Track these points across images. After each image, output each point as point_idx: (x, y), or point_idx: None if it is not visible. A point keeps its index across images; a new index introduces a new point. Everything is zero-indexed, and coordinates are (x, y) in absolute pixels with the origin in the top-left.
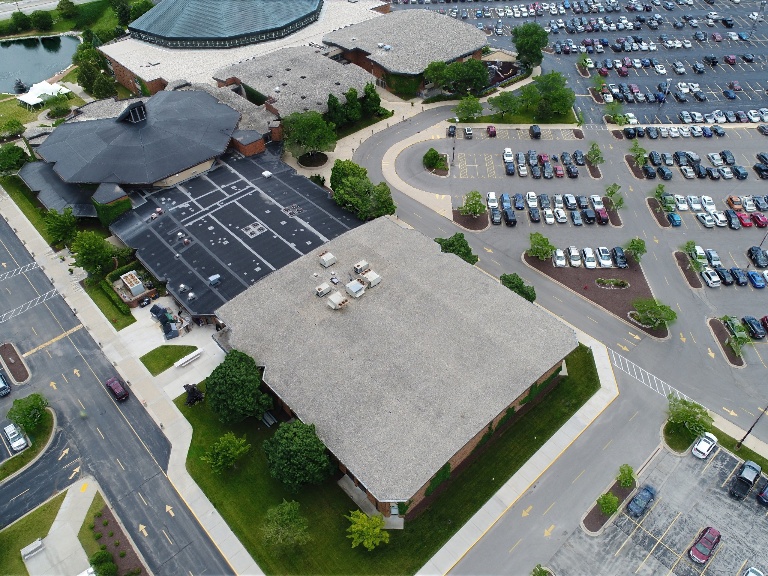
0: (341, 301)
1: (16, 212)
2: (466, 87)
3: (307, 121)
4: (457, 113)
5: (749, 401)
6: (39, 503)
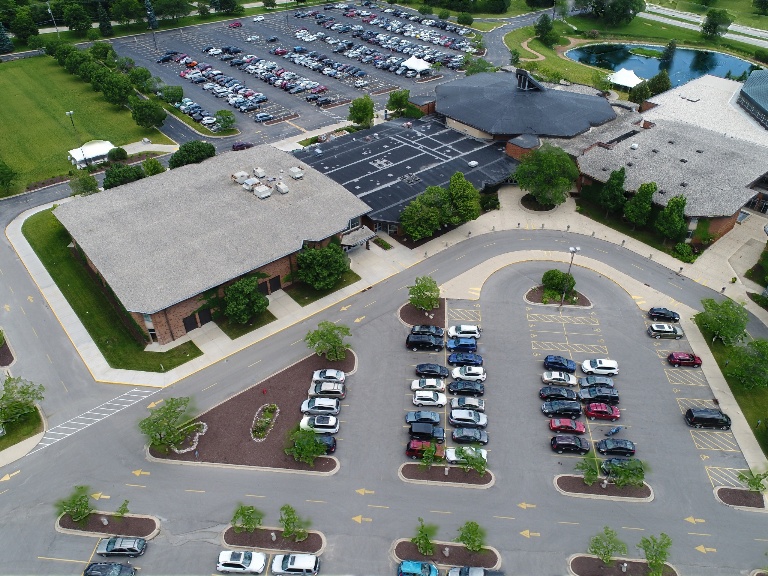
0: (236, 176)
1: None
2: None
3: (542, 154)
4: None
5: (8, 503)
6: (175, 140)
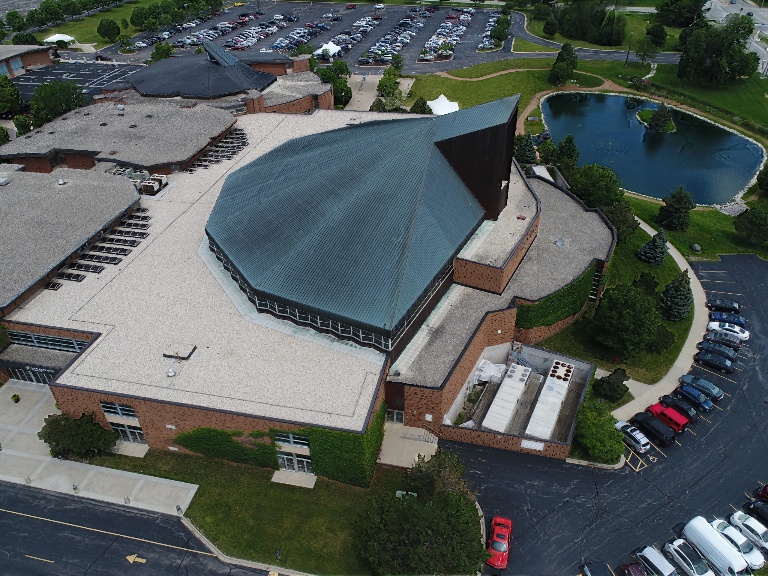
0: None
1: None
2: None
3: None
4: None
5: None
6: None
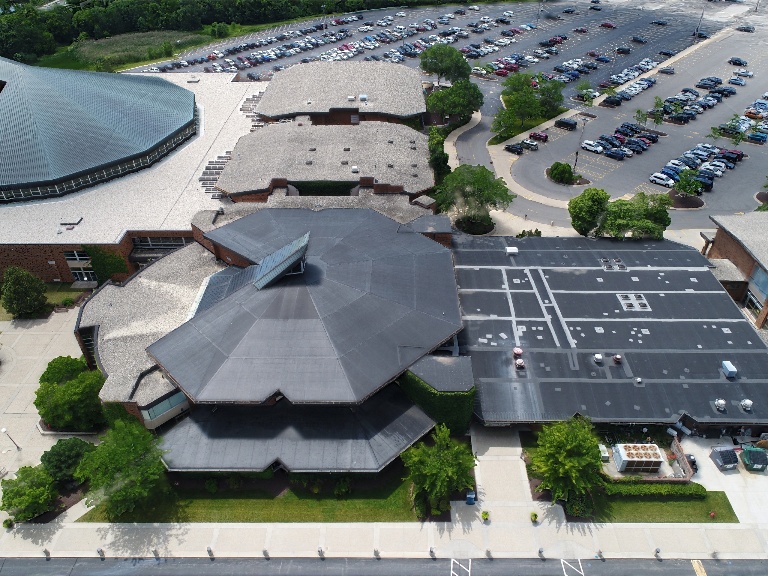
0: None
1: (251, 531)
2: (473, 109)
3: (483, 174)
4: (500, 132)
5: None
6: None
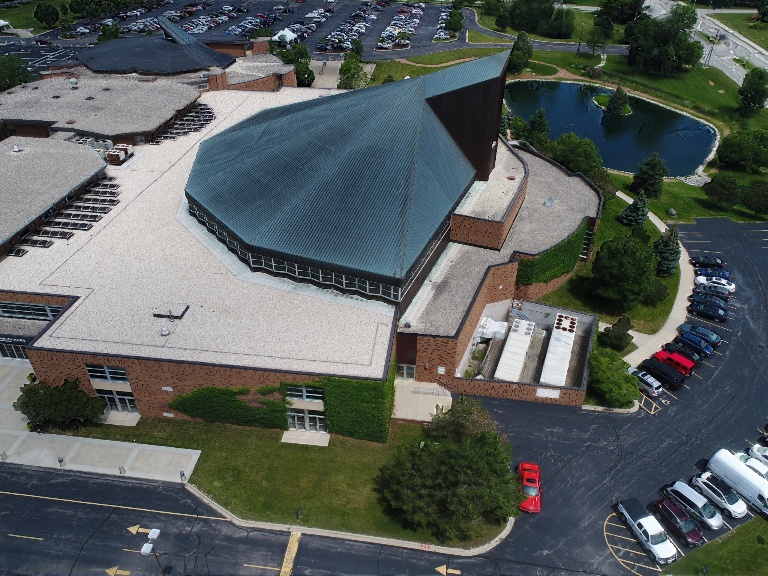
0: None
1: None
2: None
3: None
4: None
5: None
6: None
